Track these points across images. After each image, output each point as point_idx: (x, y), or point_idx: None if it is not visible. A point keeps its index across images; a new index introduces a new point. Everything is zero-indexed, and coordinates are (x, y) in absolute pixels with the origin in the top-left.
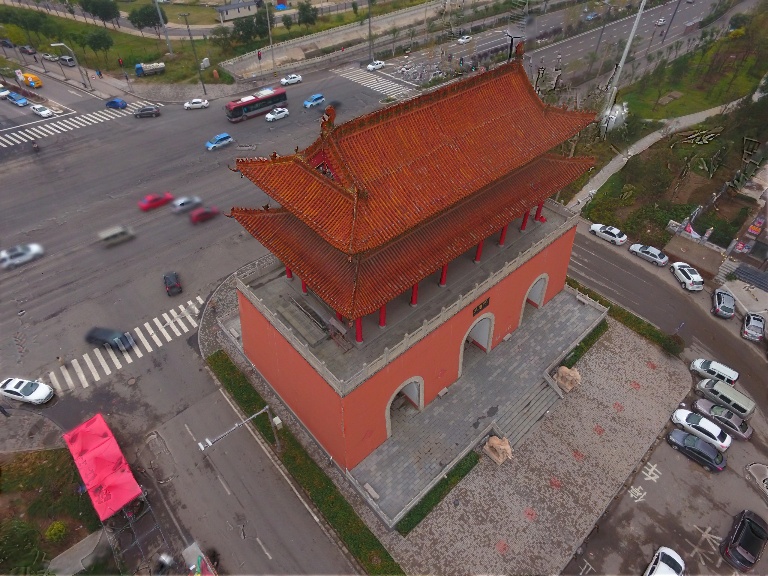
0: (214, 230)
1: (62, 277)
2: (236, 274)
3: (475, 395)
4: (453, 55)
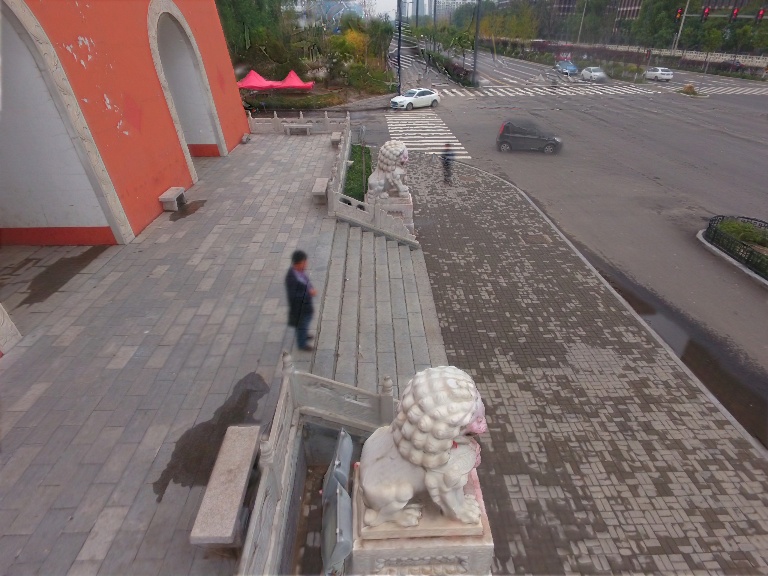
0: (756, 198)
1: (622, 118)
2: None
3: None
4: None
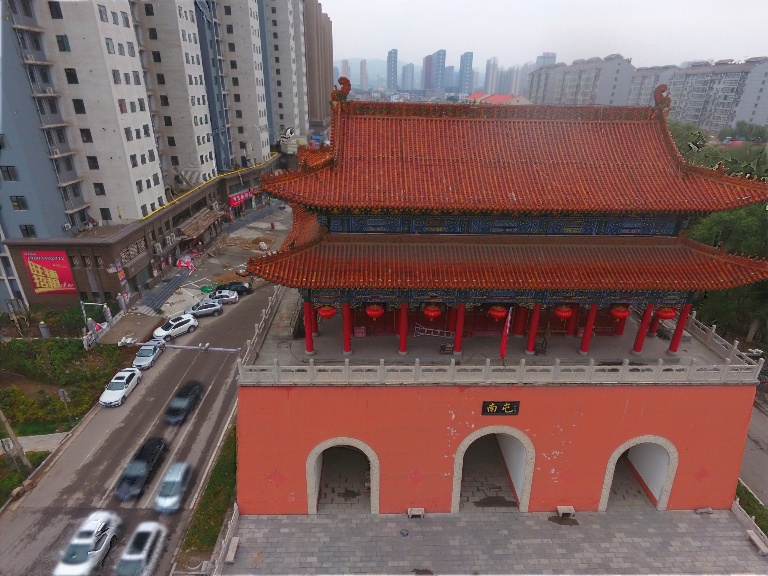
0: None
1: None
2: (761, 359)
3: None
4: None
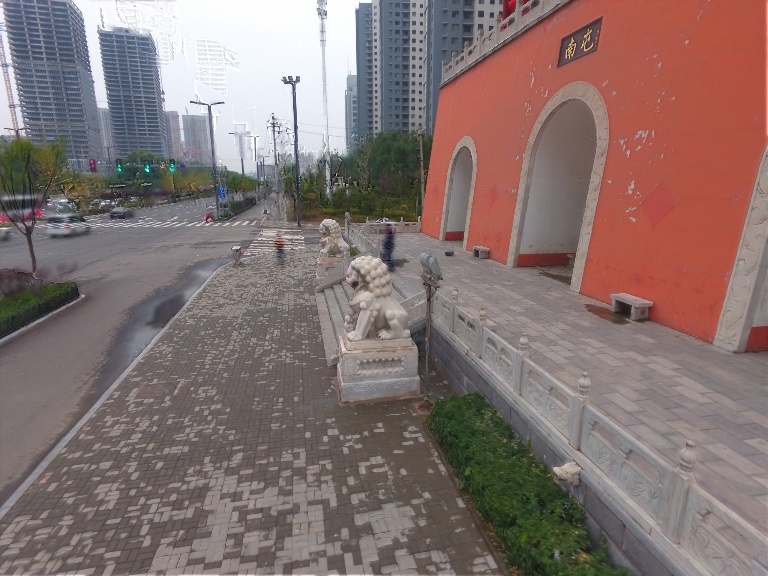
0: None
1: None
2: None
3: None
4: (98, 160)
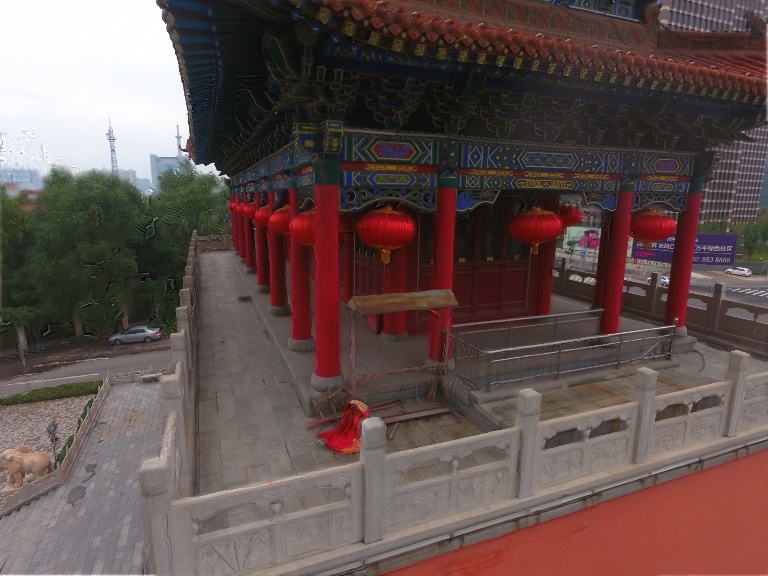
0: None
1: None
2: None
3: (131, 484)
4: None
